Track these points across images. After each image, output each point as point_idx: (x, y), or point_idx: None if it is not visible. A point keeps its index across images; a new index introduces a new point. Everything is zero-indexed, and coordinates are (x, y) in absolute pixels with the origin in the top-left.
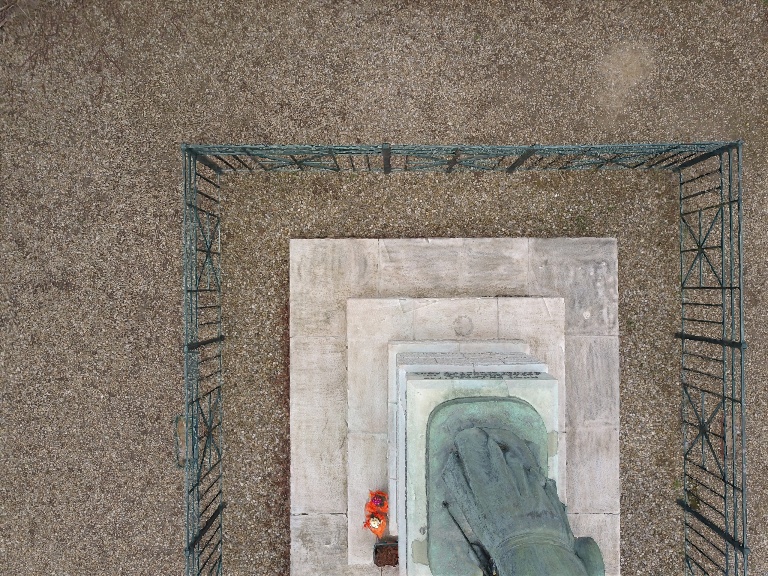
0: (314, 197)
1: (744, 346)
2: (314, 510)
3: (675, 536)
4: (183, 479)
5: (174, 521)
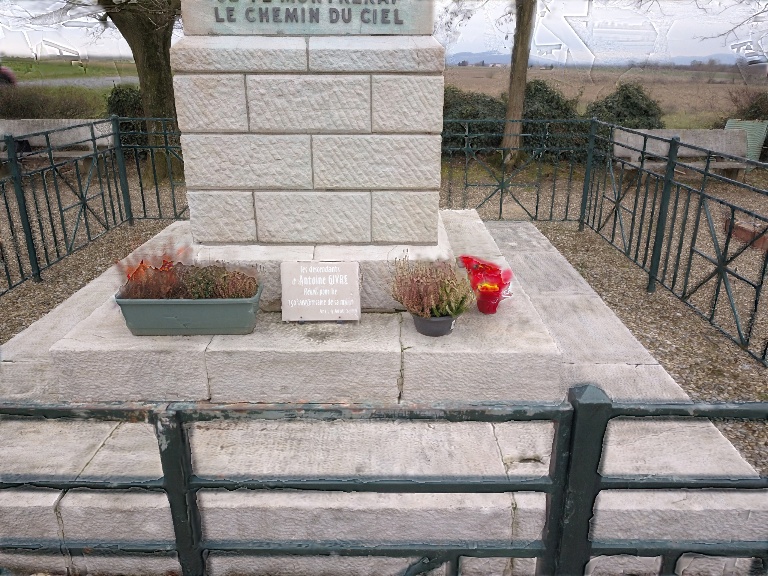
0: None
1: None
2: (33, 357)
3: None
4: None
5: None
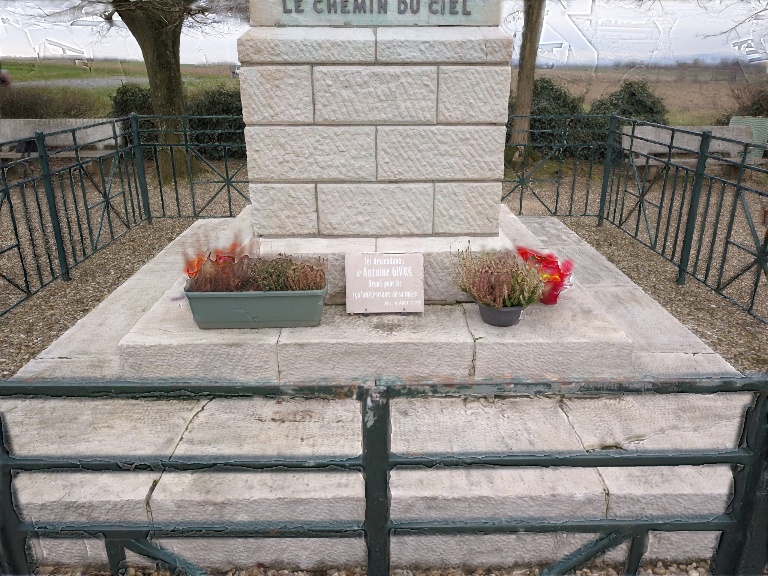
0: None
1: None
2: (88, 353)
3: None
4: None
5: None
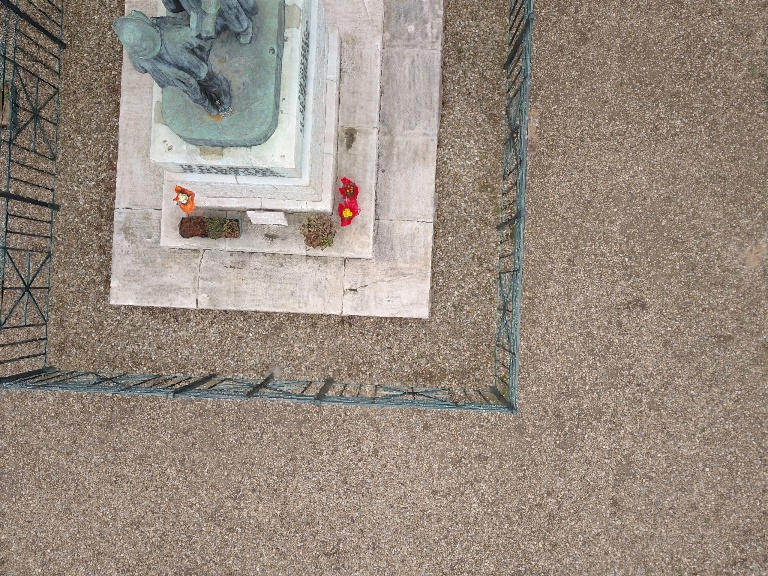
0: None
1: (531, 15)
2: (138, 205)
3: (494, 261)
4: (21, 183)
5: (10, 224)
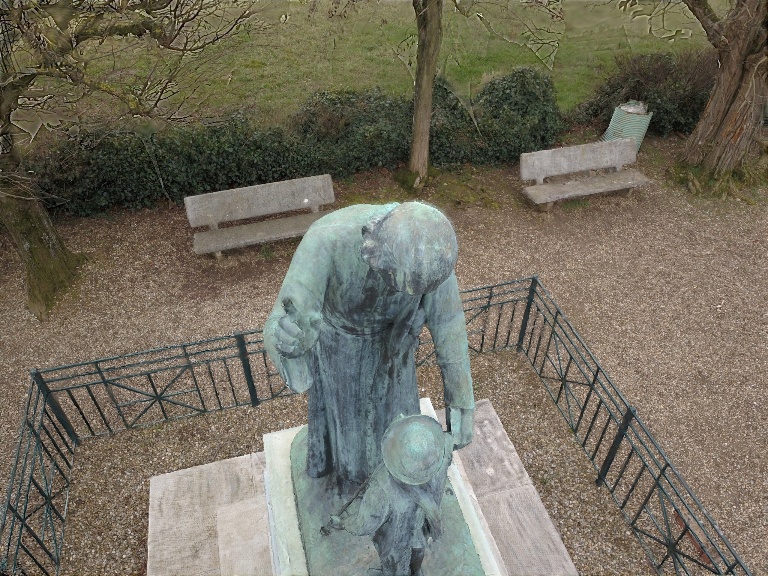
0: (180, 443)
1: (632, 408)
2: None
3: None
4: None
5: None
